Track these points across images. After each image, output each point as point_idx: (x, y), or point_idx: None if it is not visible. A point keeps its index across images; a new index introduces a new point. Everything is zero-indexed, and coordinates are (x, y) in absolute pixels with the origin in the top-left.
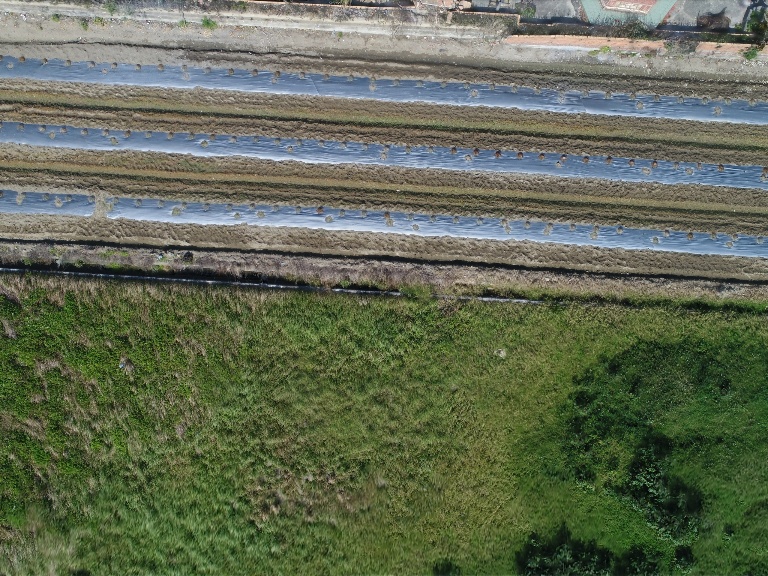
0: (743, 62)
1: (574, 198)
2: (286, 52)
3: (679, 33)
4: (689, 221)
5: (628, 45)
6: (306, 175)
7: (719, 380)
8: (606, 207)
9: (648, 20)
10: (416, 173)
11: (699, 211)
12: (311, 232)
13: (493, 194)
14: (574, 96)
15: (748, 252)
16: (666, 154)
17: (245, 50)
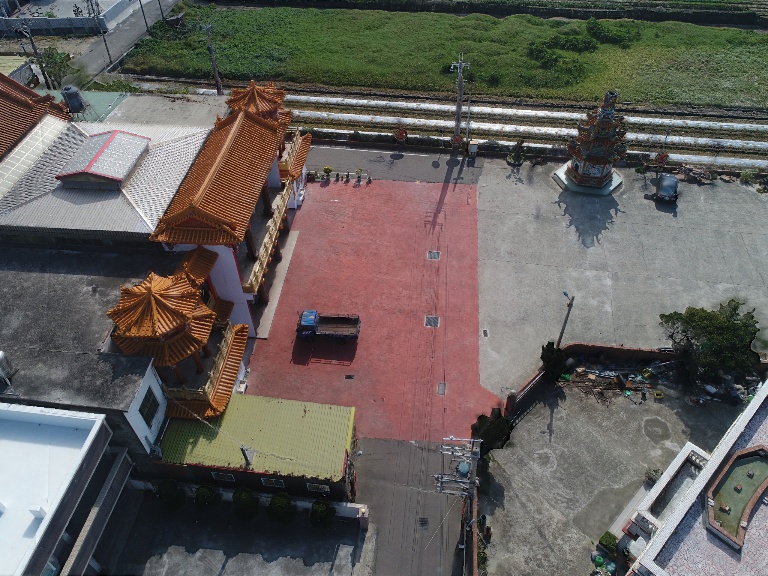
0: None
1: None
2: None
3: (559, 156)
4: None
5: None
6: (734, 137)
7: (522, 77)
8: None
9: None
10: None
11: (531, 122)
12: None
13: None
14: None
15: None
16: None
17: None
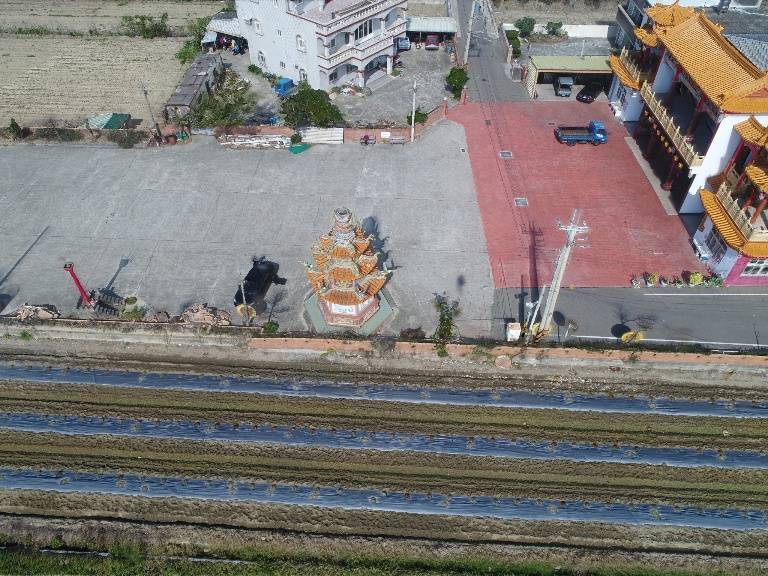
0: (443, 362)
1: (300, 463)
2: (81, 356)
3: None
4: (406, 483)
5: (346, 347)
6: (59, 444)
7: None
8: (329, 471)
9: (362, 332)
10: (159, 442)
11: (416, 475)
12: (42, 493)
13: (226, 460)
14: (307, 385)
15: (463, 511)
16: (383, 427)
17: (49, 354)
